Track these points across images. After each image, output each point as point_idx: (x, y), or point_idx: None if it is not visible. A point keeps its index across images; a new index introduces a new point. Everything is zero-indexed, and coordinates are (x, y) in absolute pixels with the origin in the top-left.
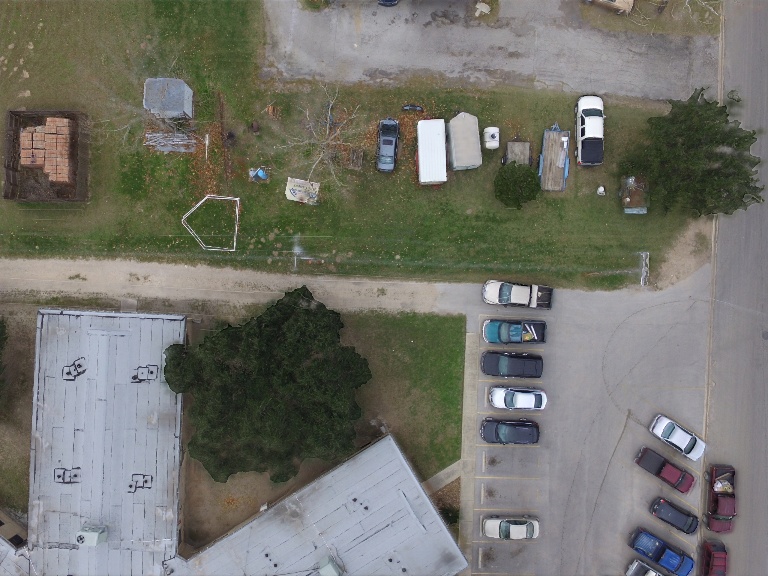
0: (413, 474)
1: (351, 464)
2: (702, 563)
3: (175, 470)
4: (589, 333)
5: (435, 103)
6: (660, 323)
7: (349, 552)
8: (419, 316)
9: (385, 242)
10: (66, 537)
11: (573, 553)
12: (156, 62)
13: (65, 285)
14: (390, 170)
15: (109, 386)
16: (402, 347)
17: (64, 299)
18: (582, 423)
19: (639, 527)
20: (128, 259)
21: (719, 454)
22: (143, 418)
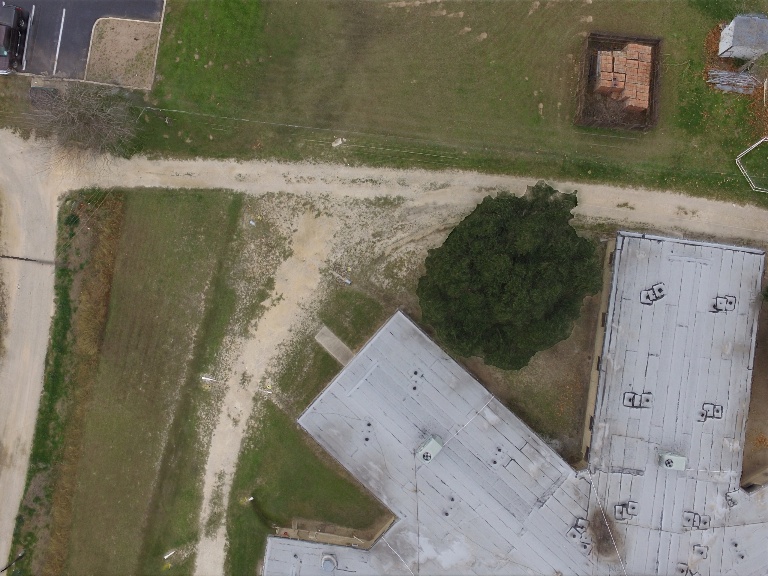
0: None
1: None
2: None
3: (746, 402)
4: None
5: None
6: None
7: None
8: None
9: None
10: (631, 462)
11: None
12: (718, 3)
13: (613, 212)
14: None
15: (691, 313)
16: None
17: (610, 226)
18: None
19: None
20: (678, 192)
21: None
22: (718, 348)
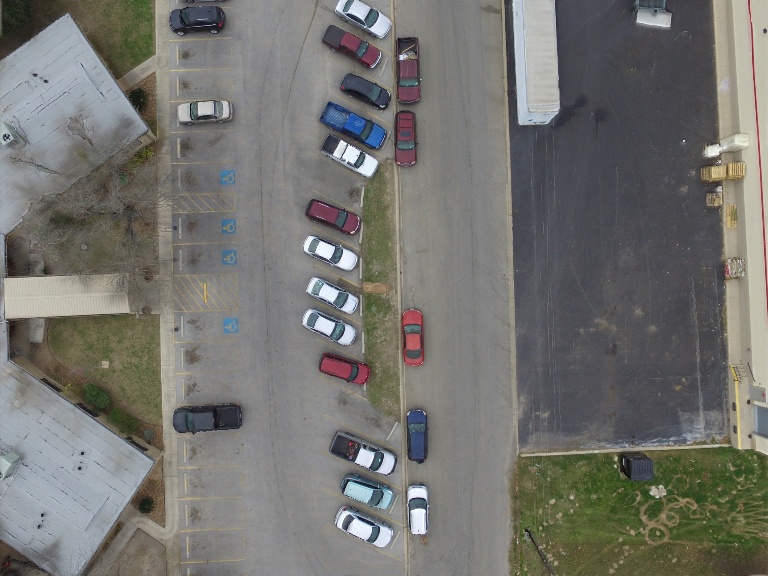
0: (91, 47)
1: (32, 43)
2: (395, 134)
3: None
4: None
5: None
6: None
7: (29, 122)
8: None
9: None
10: None
11: (271, 138)
12: None
13: None
14: None
15: None
16: None
17: None
18: (272, 13)
19: None
20: None
21: (408, 34)
22: None
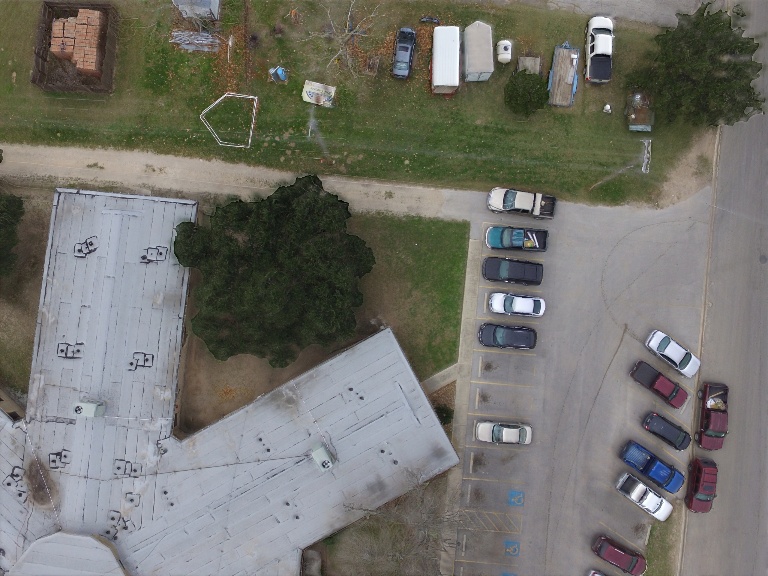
0: (410, 367)
1: (350, 354)
2: (693, 481)
3: (176, 350)
4: (590, 247)
5: (451, 17)
6: (660, 241)
7: (342, 440)
8: (424, 220)
9: (395, 147)
10: (64, 411)
11: (564, 464)
12: None
13: (83, 172)
14: (404, 77)
15: (118, 264)
16: (406, 249)
17: (81, 186)
18: (579, 335)
19: (631, 440)
20: (146, 150)
21: (713, 374)
22: (149, 298)
